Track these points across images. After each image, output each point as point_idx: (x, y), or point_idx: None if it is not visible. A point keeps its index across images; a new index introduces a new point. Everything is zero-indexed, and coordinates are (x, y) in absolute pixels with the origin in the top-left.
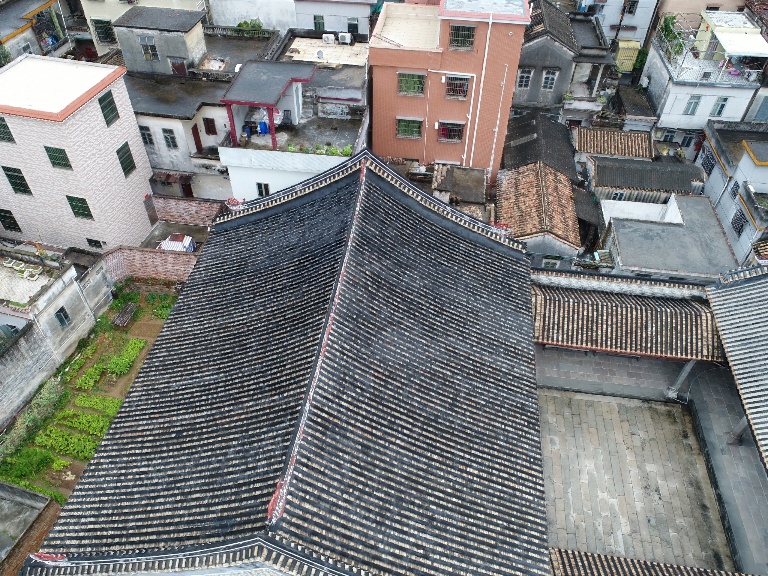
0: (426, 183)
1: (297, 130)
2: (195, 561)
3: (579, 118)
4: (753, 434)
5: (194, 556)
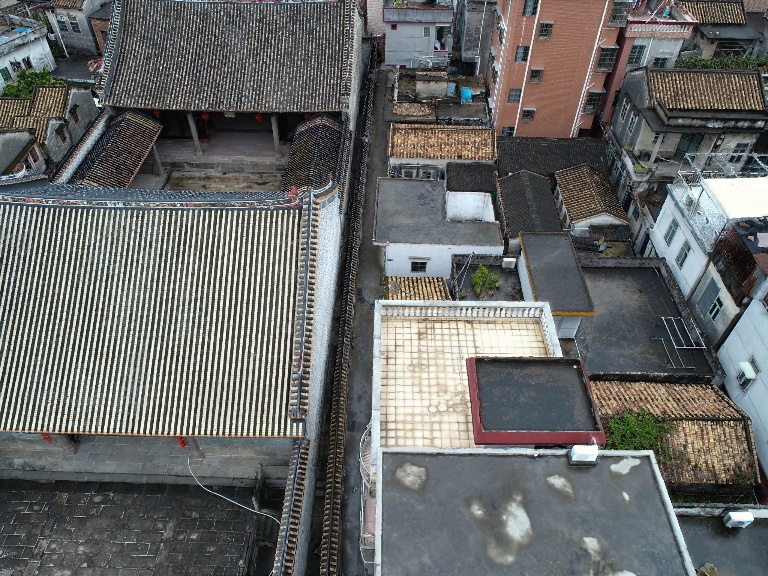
0: (456, 95)
1: (430, 3)
2: None
3: (624, 177)
4: None
5: None
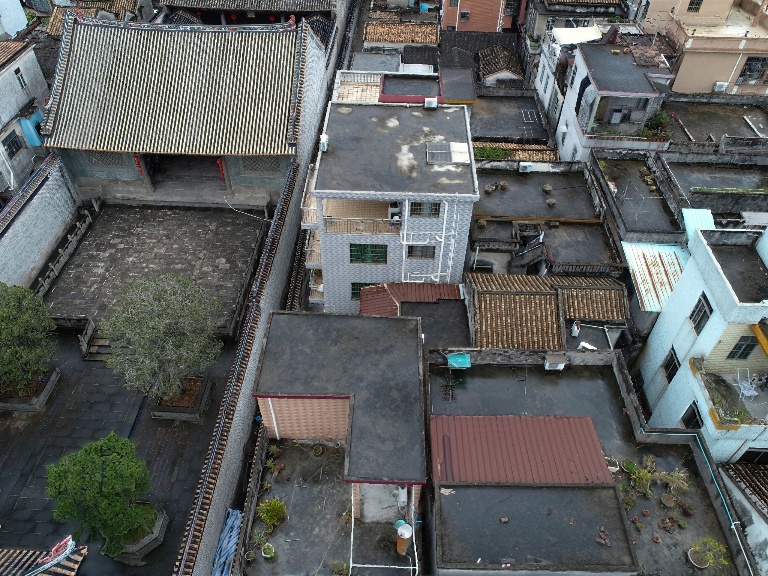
0: None
1: None
2: None
3: None
4: None
5: None
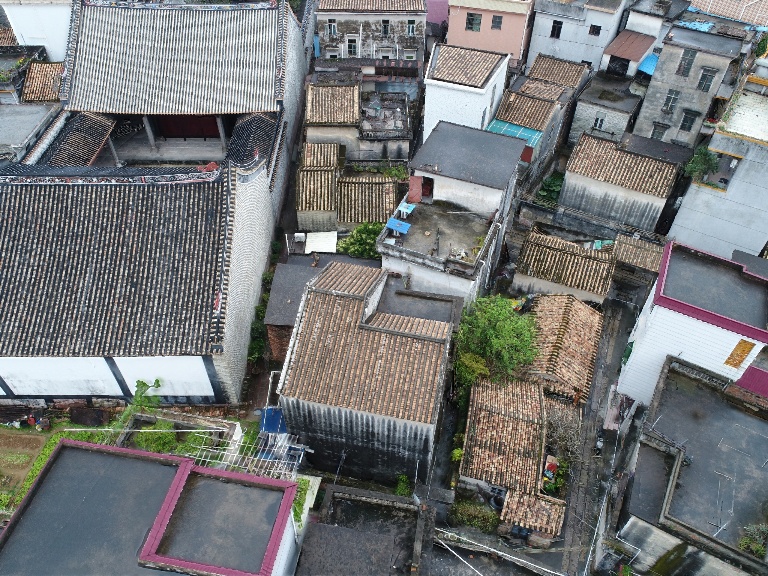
0: None
1: None
2: (231, 211)
3: None
4: (168, 115)
5: (229, 210)
